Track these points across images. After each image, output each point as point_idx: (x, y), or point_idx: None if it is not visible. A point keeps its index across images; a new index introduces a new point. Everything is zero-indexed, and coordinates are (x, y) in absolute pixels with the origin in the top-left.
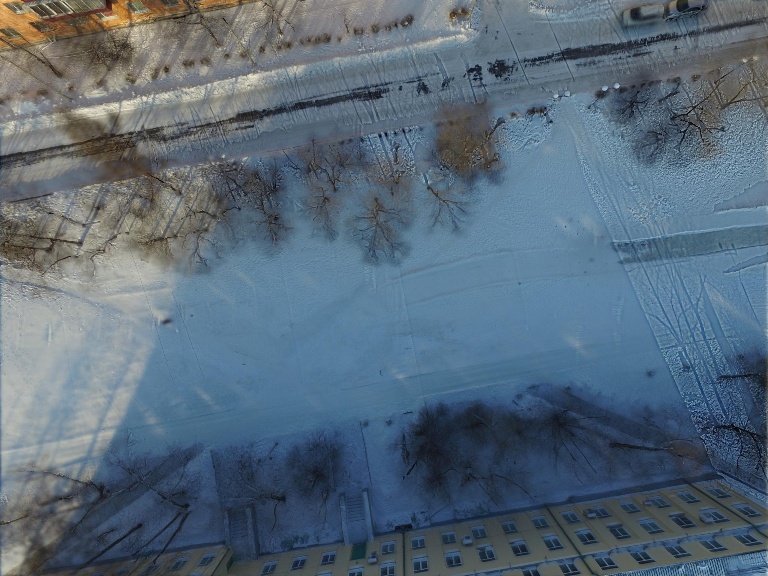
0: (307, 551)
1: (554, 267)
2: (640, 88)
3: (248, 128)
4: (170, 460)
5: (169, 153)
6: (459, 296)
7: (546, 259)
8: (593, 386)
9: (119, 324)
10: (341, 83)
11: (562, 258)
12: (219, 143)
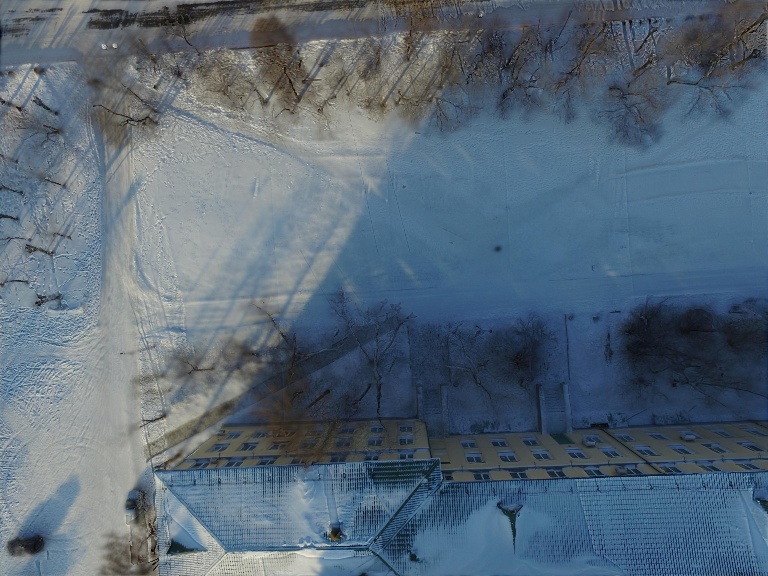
0: (502, 436)
1: None
2: None
3: (484, 1)
4: (364, 331)
5: (399, 18)
6: (684, 199)
7: None
8: None
9: (328, 187)
10: None
11: None
12: (452, 13)
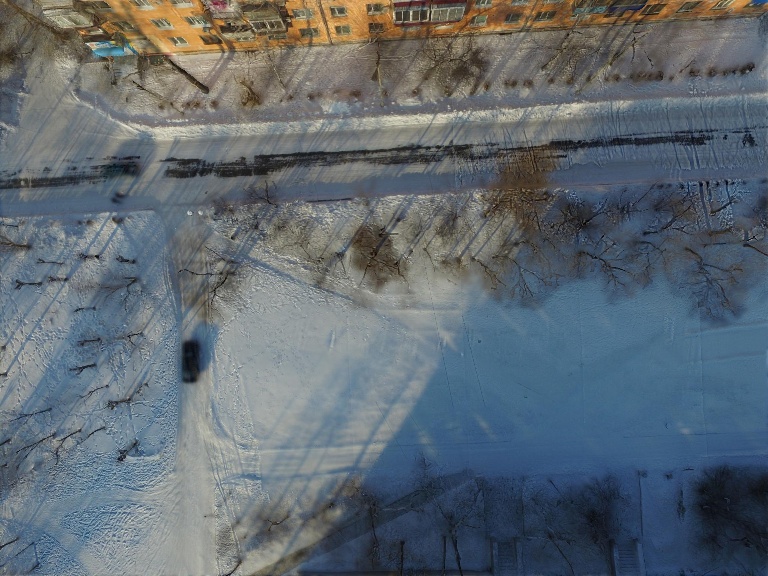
0: None
1: None
2: None
3: (560, 158)
4: (438, 482)
5: (475, 172)
6: (759, 359)
7: None
8: None
9: (404, 340)
10: (664, 124)
11: None
12: (528, 169)
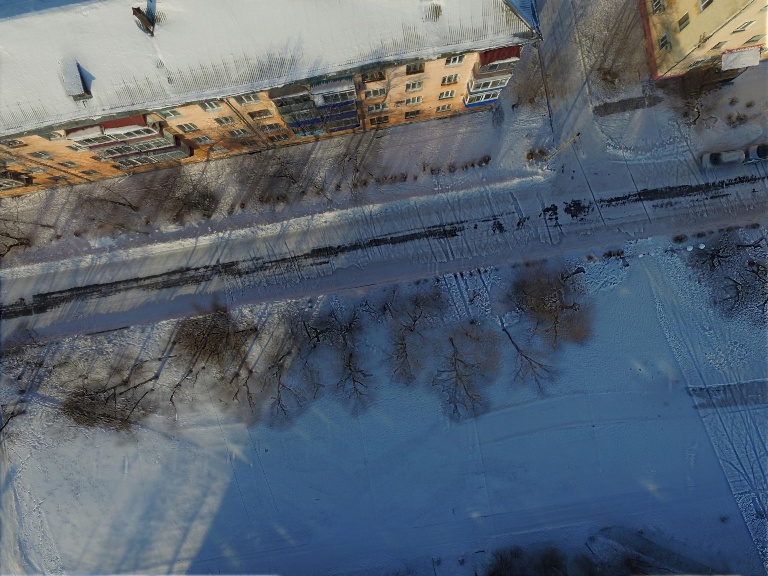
0: None
1: (628, 410)
2: (718, 233)
3: (323, 264)
4: None
5: (244, 288)
6: (532, 437)
7: (620, 402)
8: (666, 531)
9: (194, 457)
10: (416, 221)
11: (636, 401)
12: (294, 278)
